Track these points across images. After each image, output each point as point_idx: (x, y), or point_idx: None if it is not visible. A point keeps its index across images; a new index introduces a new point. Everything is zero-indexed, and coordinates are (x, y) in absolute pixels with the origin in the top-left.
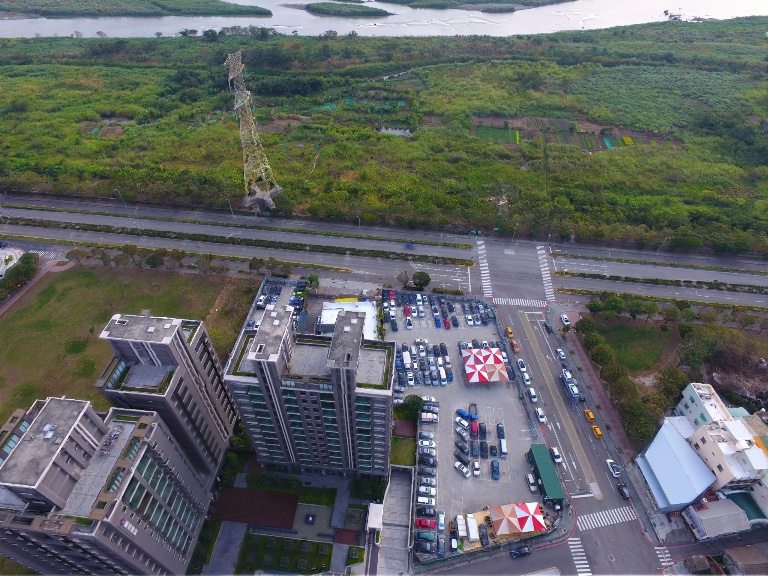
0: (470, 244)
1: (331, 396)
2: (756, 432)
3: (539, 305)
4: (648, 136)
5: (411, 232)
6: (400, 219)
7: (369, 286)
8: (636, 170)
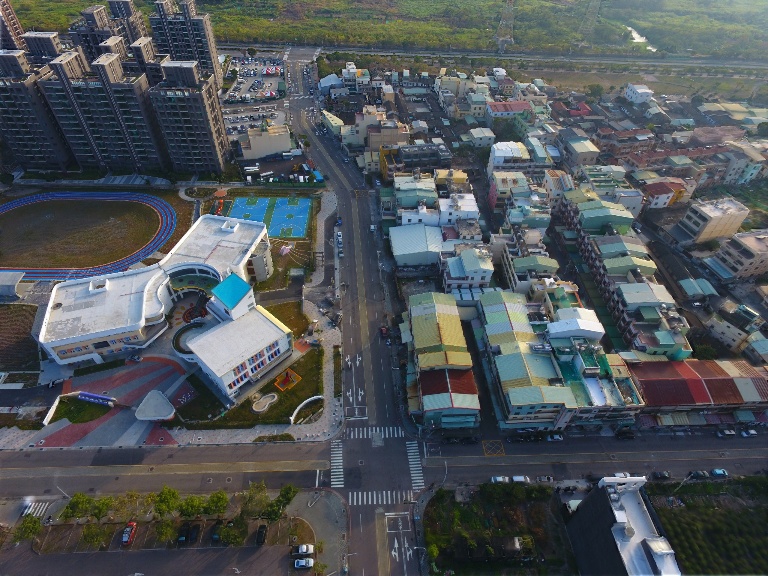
0: (283, 47)
1: (185, 24)
2: (362, 70)
3: (307, 61)
4: (412, 19)
5: (255, 45)
6: (248, 37)
7: None
8: (393, 30)
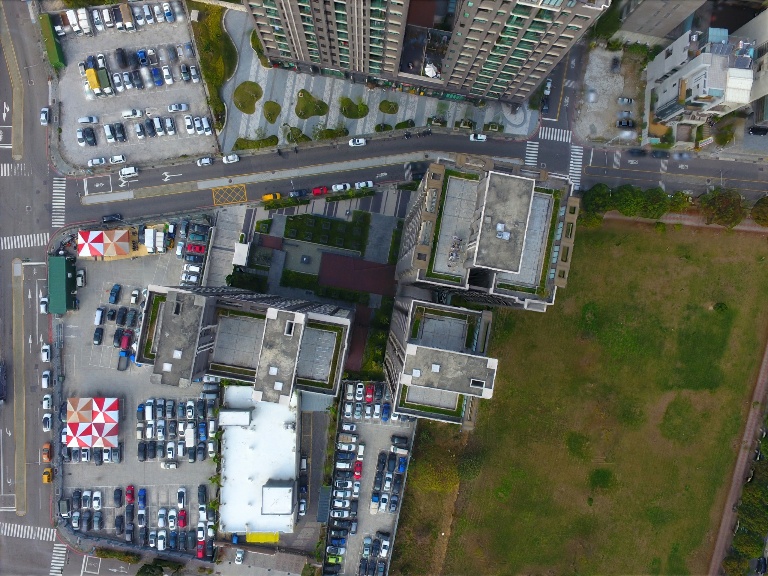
0: None
1: None
2: None
3: None
4: None
5: None
6: None
7: (233, 572)
8: None
